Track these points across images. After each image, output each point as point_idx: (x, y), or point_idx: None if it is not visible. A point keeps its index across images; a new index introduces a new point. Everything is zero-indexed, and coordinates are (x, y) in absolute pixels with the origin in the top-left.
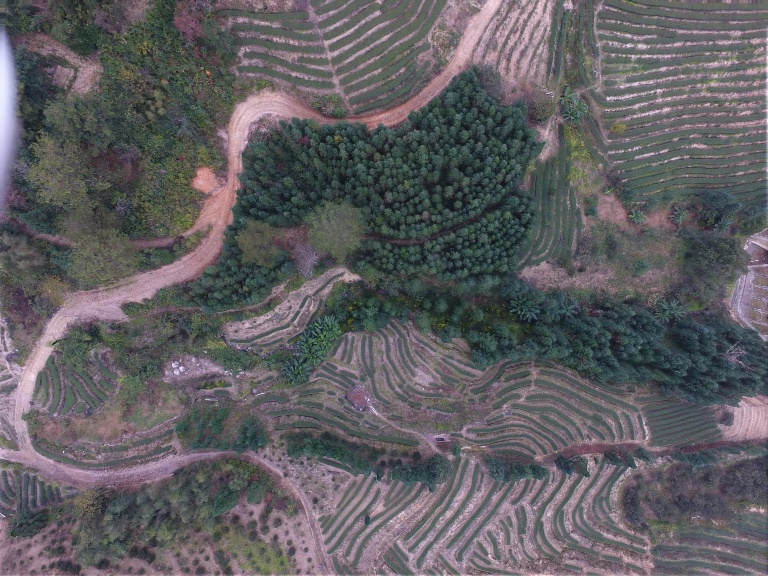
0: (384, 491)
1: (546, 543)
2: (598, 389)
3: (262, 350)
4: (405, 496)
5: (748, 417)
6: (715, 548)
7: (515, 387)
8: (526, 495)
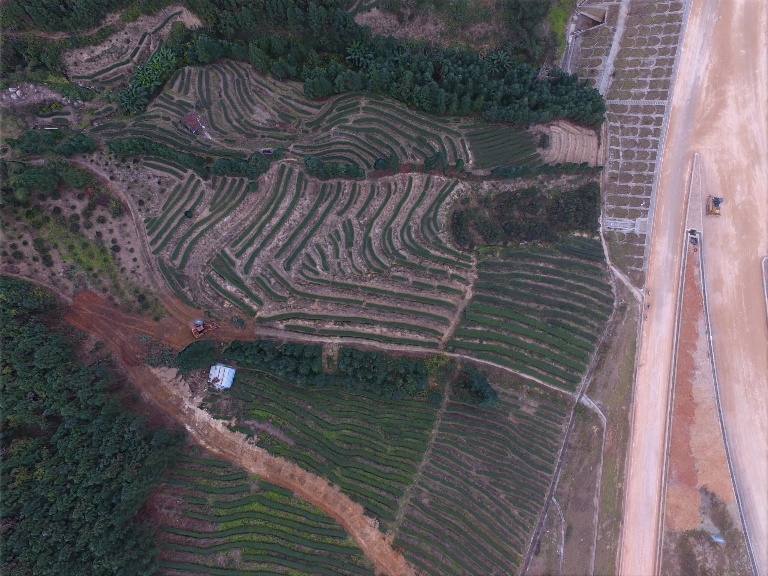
0: (209, 195)
1: (374, 257)
2: (424, 118)
3: (104, 88)
4: (230, 199)
5: (566, 143)
6: (538, 264)
7: (344, 115)
8: (351, 207)
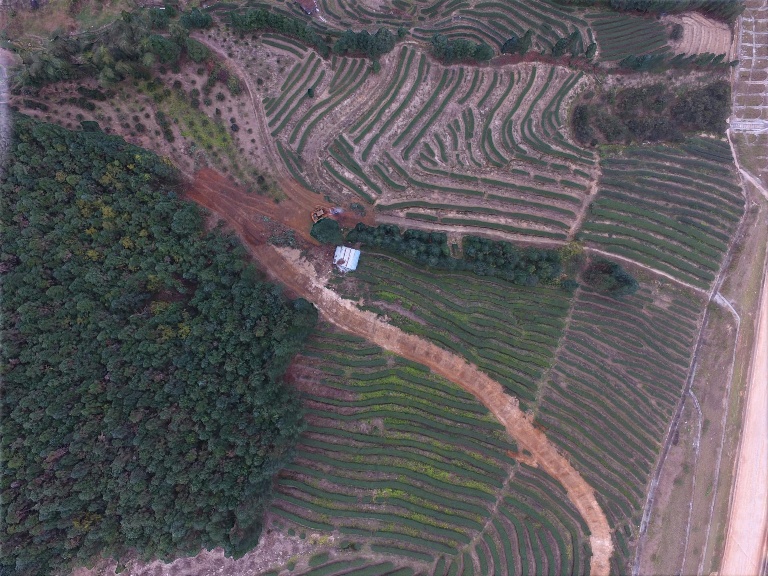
0: (329, 77)
1: (494, 150)
2: (548, 6)
3: None
4: (350, 81)
5: (698, 36)
6: (664, 163)
7: None
8: (473, 95)
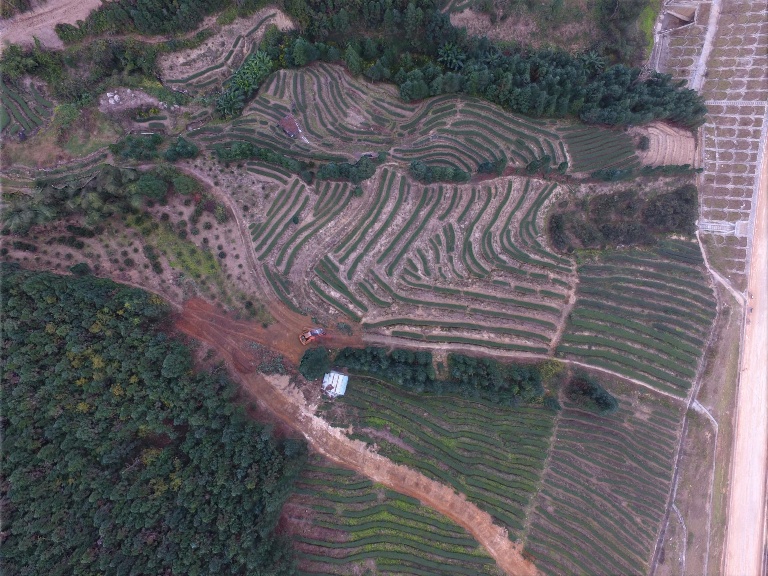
0: (313, 201)
1: (475, 262)
2: (521, 121)
3: (198, 92)
4: (334, 205)
5: (664, 145)
6: (638, 268)
7: (441, 118)
8: (453, 211)
